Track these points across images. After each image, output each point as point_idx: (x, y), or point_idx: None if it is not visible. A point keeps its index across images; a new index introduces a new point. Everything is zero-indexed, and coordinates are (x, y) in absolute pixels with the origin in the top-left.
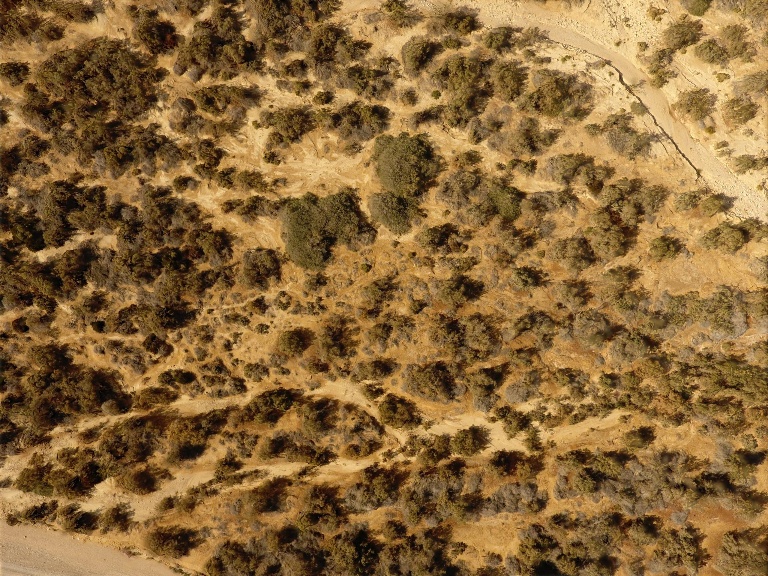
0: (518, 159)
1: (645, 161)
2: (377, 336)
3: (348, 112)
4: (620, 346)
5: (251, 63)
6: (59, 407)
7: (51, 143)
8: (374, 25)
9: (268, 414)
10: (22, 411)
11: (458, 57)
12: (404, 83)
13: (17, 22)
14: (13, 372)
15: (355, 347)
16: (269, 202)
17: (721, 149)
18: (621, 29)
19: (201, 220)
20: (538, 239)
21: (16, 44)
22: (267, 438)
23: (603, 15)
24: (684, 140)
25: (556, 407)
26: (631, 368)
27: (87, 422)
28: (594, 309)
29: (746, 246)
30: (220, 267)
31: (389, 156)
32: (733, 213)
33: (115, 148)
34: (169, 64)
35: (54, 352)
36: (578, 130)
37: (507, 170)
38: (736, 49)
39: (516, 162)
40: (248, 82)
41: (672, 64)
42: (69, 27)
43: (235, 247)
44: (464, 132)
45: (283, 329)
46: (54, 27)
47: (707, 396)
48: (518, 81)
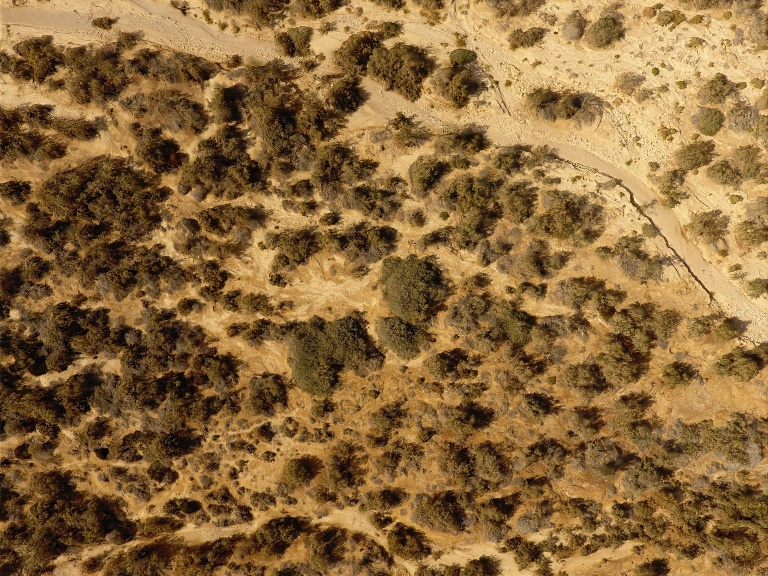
0: (528, 282)
1: (657, 285)
2: (386, 466)
3: (355, 236)
4: (633, 478)
5: (256, 184)
6: (62, 540)
7: (53, 264)
8: (381, 144)
9: (275, 546)
10: (25, 542)
11: (466, 177)
12: (412, 203)
13: (19, 143)
14: (15, 501)
15: (363, 476)
16: (275, 326)
17: (734, 272)
18: (632, 148)
19: (206, 344)
20: (549, 365)
21: (18, 162)
22: (274, 570)
23: (613, 134)
24: (696, 262)
25: (568, 537)
26: (644, 497)
27: (91, 550)
28: (606, 437)
29: (760, 373)
30: (226, 394)
31: (397, 282)
32: (747, 338)
33: (119, 273)
34: (173, 183)
35: (57, 482)
36: (589, 253)
37: (517, 294)
38: (749, 172)
39: (526, 287)
40: (253, 202)
41: (684, 185)
42: (71, 144)
43: (241, 372)
44: (473, 254)
45: (290, 457)
46: (56, 145)
47: (722, 526)
48: (528, 203)
